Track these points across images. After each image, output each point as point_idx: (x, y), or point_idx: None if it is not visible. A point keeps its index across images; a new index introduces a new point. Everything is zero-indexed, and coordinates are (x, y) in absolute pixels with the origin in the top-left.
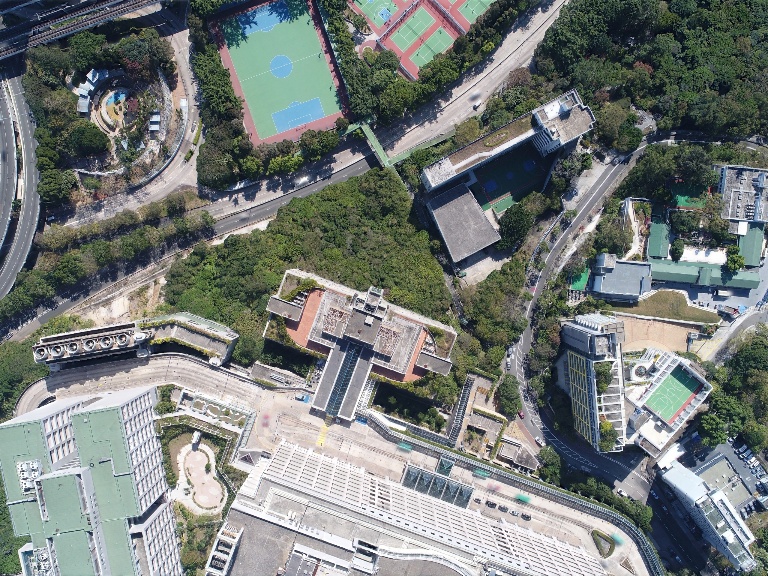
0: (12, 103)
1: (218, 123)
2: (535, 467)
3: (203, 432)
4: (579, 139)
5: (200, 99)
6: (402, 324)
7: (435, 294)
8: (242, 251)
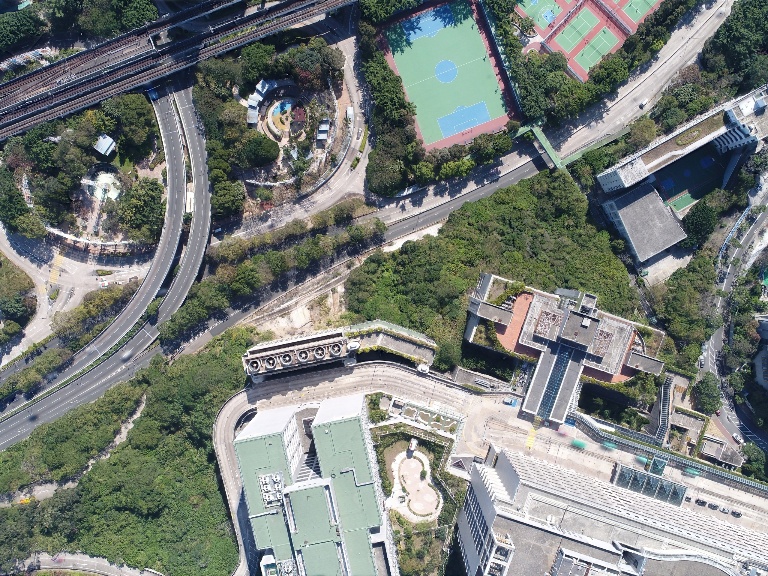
0: (179, 116)
1: (390, 130)
2: (740, 464)
3: (419, 439)
4: None
5: (365, 106)
6: (613, 325)
7: (624, 294)
8: (423, 257)
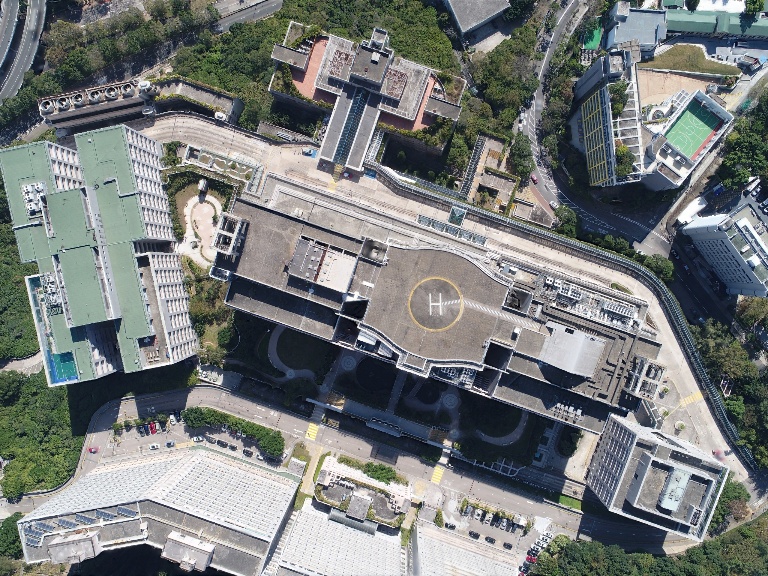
0: None
1: None
2: (550, 224)
3: (209, 181)
4: None
5: None
6: (410, 68)
7: (444, 62)
8: (247, 34)
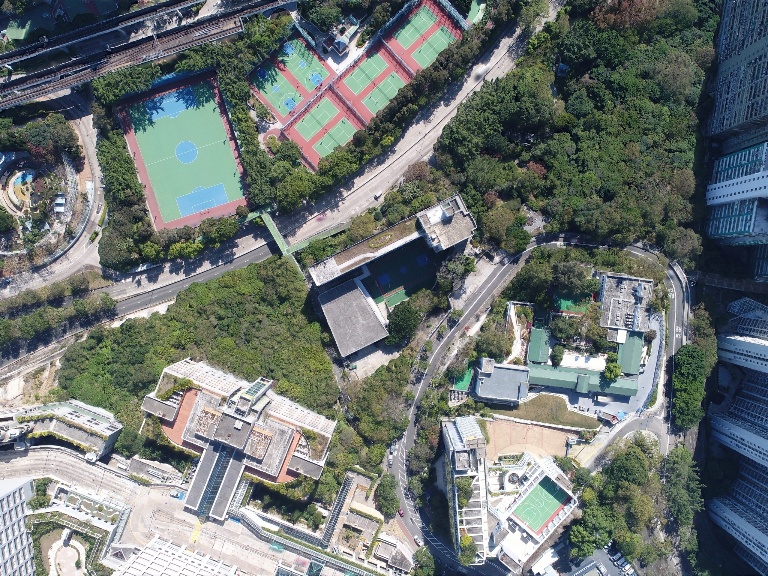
0: None
1: (119, 208)
2: (409, 569)
3: (74, 529)
4: (469, 238)
5: None
6: (275, 427)
7: (321, 389)
8: (136, 337)
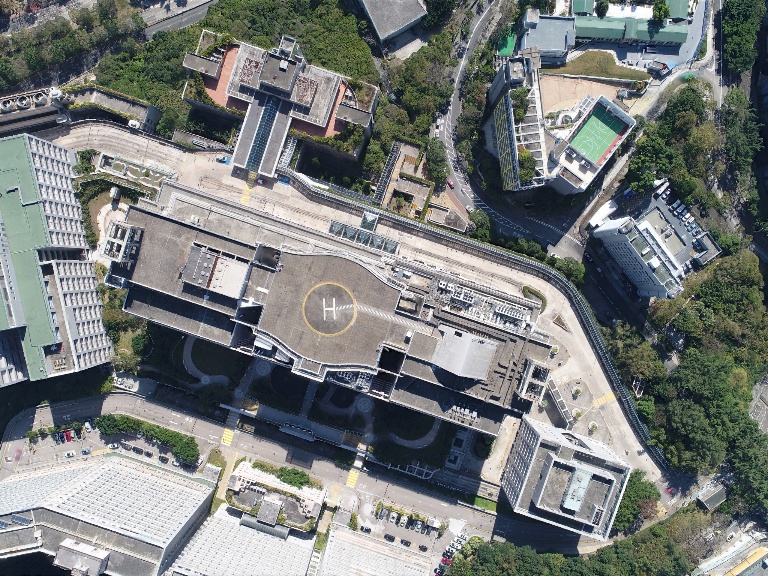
0: None
1: None
2: (464, 228)
3: (122, 189)
4: None
5: None
6: (320, 75)
7: (361, 69)
8: (170, 42)
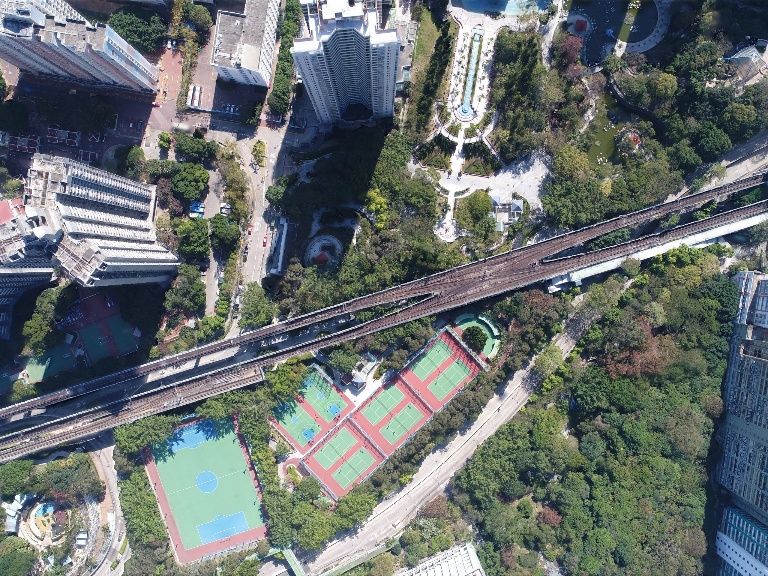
0: None
1: (142, 548)
2: None
3: None
4: None
5: None
6: None
7: None
8: None
